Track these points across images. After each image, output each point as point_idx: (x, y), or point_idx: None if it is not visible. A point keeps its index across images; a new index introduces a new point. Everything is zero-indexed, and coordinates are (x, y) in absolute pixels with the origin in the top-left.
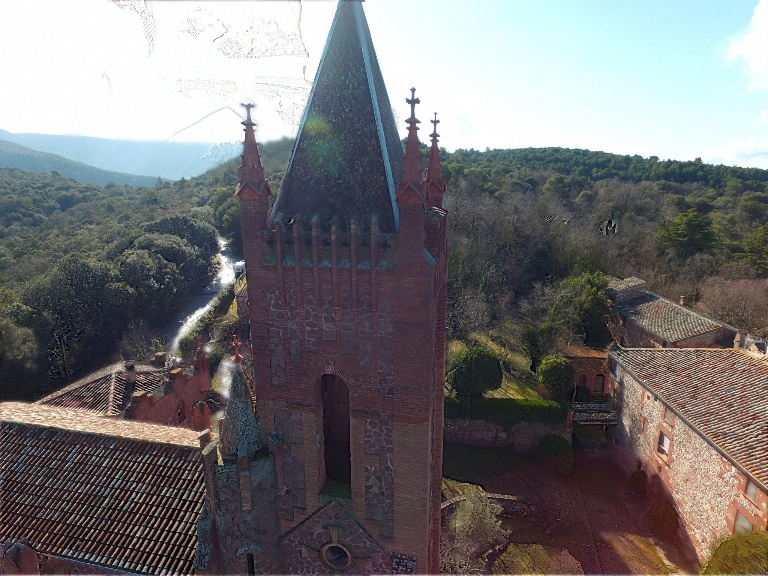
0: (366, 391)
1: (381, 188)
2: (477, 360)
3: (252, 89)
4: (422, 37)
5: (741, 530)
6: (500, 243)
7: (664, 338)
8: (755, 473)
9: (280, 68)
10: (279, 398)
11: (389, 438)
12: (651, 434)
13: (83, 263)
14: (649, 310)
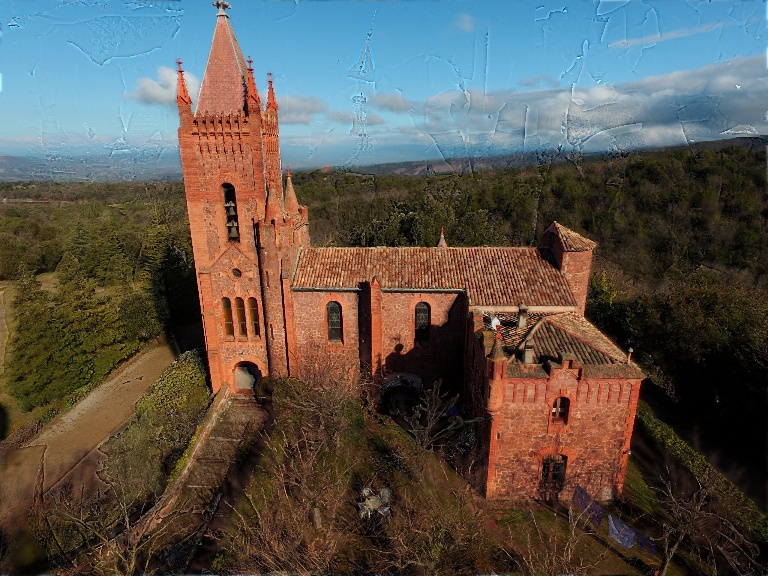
0: None
1: None
2: None
3: None
4: None
5: None
6: None
7: None
8: None
9: None
10: None
11: None
12: None
13: None
14: None
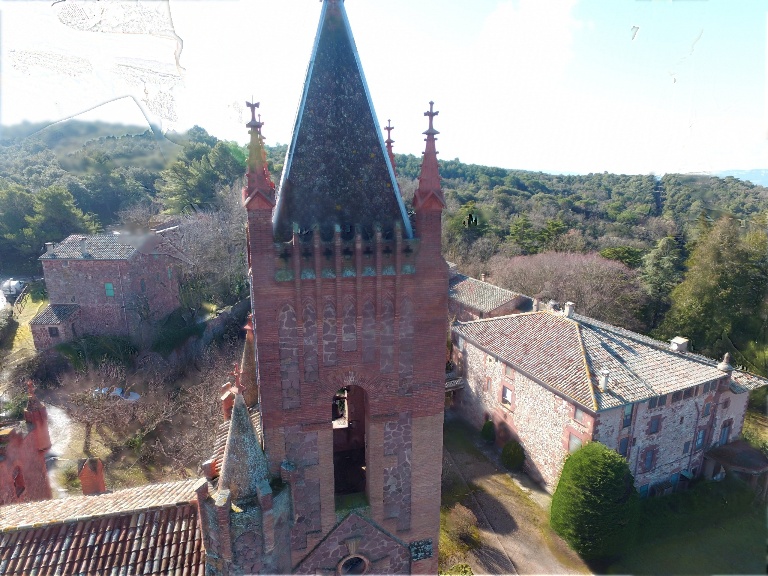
0: (386, 395)
1: (388, 195)
2: None
3: (111, 71)
4: None
5: (573, 447)
6: None
7: (481, 310)
8: (582, 401)
9: (148, 50)
10: (291, 422)
11: (407, 435)
12: (495, 390)
13: None
14: (464, 288)
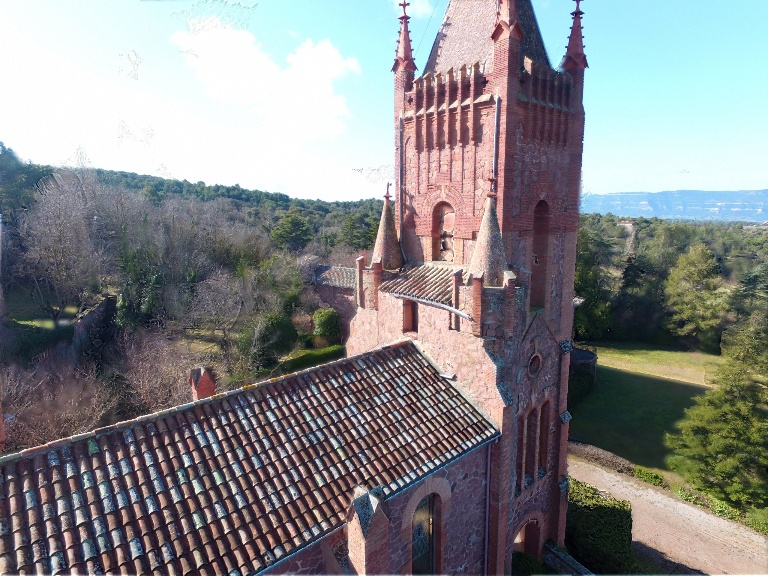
0: None
1: (545, 59)
2: (278, 324)
3: None
4: None
5: None
6: (191, 234)
7: None
8: None
9: None
10: (515, 228)
11: (562, 247)
12: None
13: None
14: (332, 275)
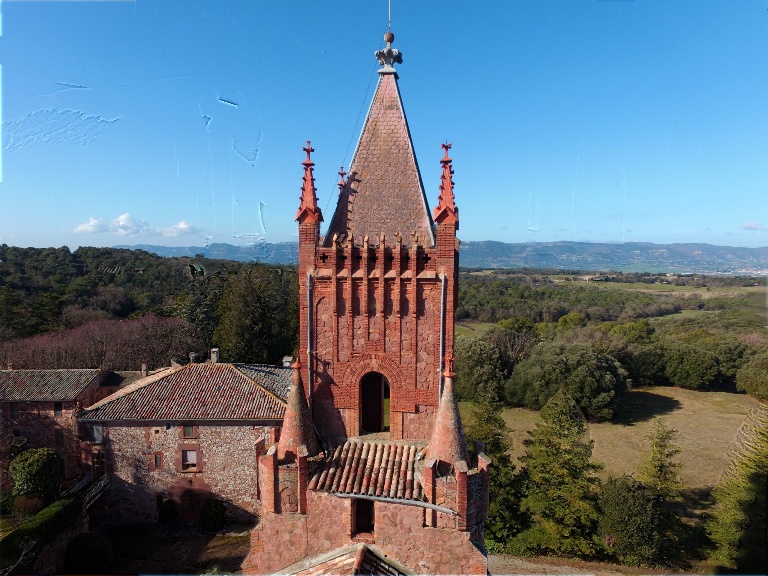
0: None
1: None
2: None
3: None
4: (163, 57)
5: None
6: None
7: (61, 399)
8: None
9: None
10: None
11: None
12: (170, 461)
13: None
14: (4, 385)
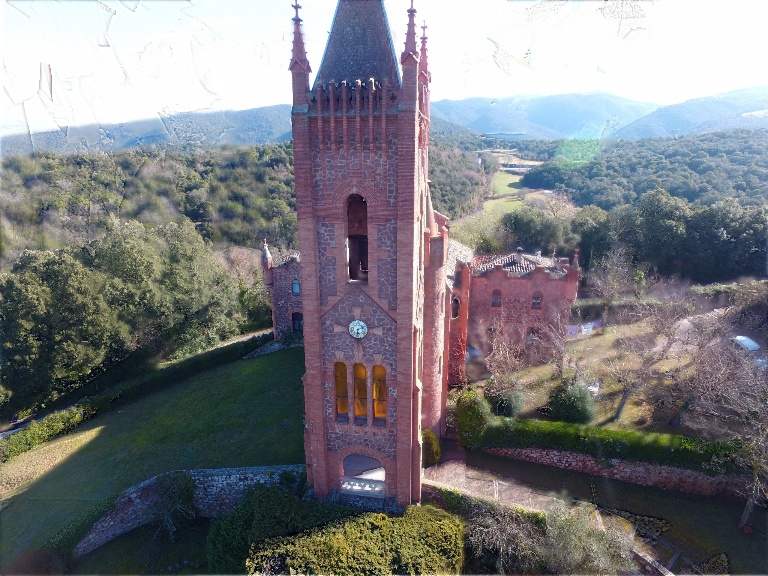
0: None
1: None
2: None
3: None
4: None
5: None
6: None
7: None
8: None
9: None
10: None
11: None
12: None
13: (657, 198)
14: None
